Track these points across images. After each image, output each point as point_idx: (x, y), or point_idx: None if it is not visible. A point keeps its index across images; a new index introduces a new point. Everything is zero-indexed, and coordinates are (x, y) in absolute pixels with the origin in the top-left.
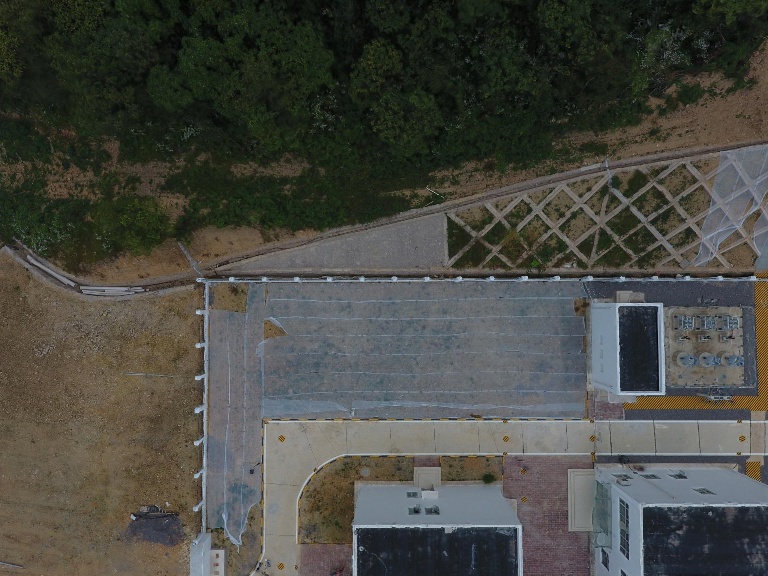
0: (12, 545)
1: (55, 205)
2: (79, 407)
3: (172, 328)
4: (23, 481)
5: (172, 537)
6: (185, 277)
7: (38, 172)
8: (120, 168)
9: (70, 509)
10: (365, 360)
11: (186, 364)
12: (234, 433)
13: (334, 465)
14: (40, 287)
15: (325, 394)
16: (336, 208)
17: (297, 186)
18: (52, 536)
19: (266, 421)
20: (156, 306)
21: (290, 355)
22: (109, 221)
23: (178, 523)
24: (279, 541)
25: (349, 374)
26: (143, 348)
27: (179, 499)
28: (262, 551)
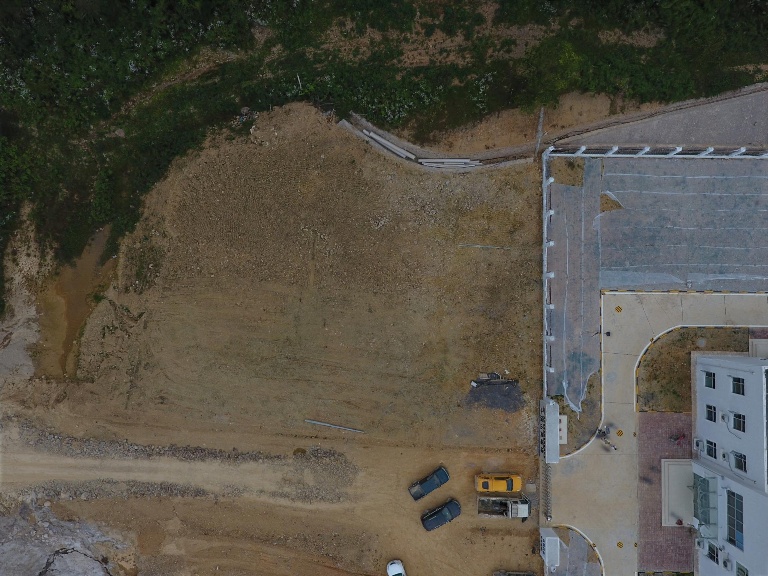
0: (352, 411)
1: (418, 71)
2: (417, 277)
3: (508, 201)
4: (362, 349)
5: (515, 403)
6: (520, 152)
7: (389, 43)
8: (495, 31)
9: (409, 376)
10: (700, 234)
11: (522, 236)
12: (572, 303)
13: (671, 335)
14: (377, 160)
15: (661, 266)
16: (687, 80)
17: (651, 57)
18: (392, 402)
19: (603, 292)
20: (493, 179)
21: (626, 228)
22: (548, 59)
23: (518, 390)
24: (618, 409)
25: (685, 247)
26: (479, 221)
27: (518, 367)
28: (601, 418)
